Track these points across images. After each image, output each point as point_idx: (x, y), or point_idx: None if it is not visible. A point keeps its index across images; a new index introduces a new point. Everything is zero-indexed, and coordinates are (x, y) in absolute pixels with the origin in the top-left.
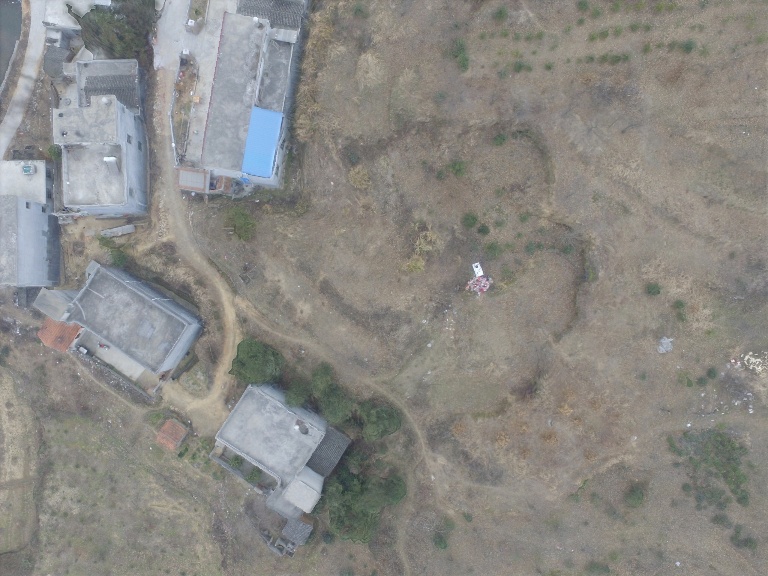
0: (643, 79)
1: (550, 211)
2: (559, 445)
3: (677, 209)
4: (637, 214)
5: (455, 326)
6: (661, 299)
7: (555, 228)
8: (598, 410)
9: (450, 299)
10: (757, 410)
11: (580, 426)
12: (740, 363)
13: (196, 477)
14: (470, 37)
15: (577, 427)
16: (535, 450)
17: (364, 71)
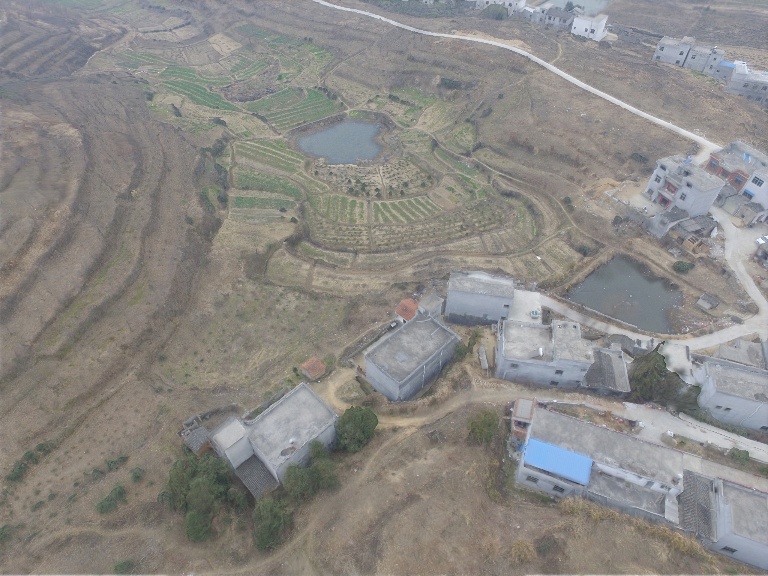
0: None
1: None
2: None
3: None
4: None
5: None
6: None
7: None
8: None
9: None
10: None
11: None
12: None
13: (273, 380)
14: None
15: None
16: None
17: (642, 575)
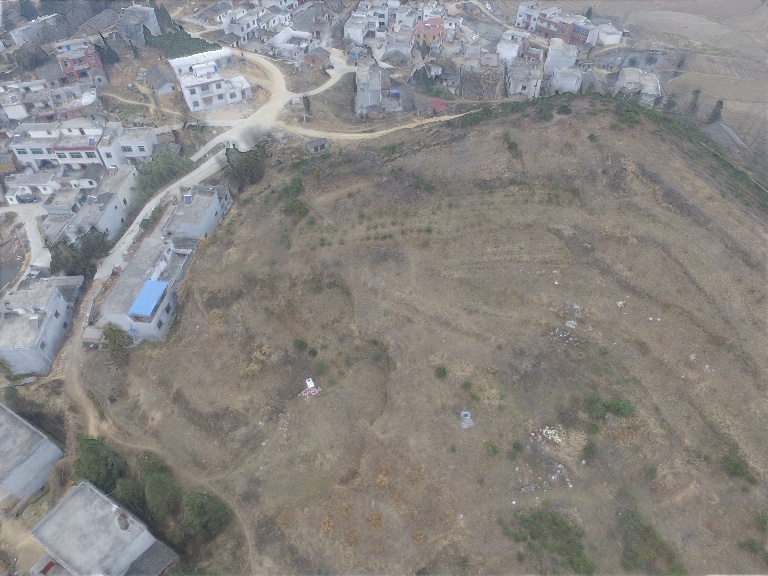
0: (406, 248)
1: (356, 327)
2: (385, 528)
3: (445, 316)
4: (419, 323)
5: (288, 426)
6: (452, 382)
7: (367, 345)
8: (416, 484)
9: (285, 405)
10: (575, 483)
11: (402, 503)
12: (541, 437)
13: None
14: (293, 234)
15: (400, 505)
16: (362, 538)
17: (226, 257)
